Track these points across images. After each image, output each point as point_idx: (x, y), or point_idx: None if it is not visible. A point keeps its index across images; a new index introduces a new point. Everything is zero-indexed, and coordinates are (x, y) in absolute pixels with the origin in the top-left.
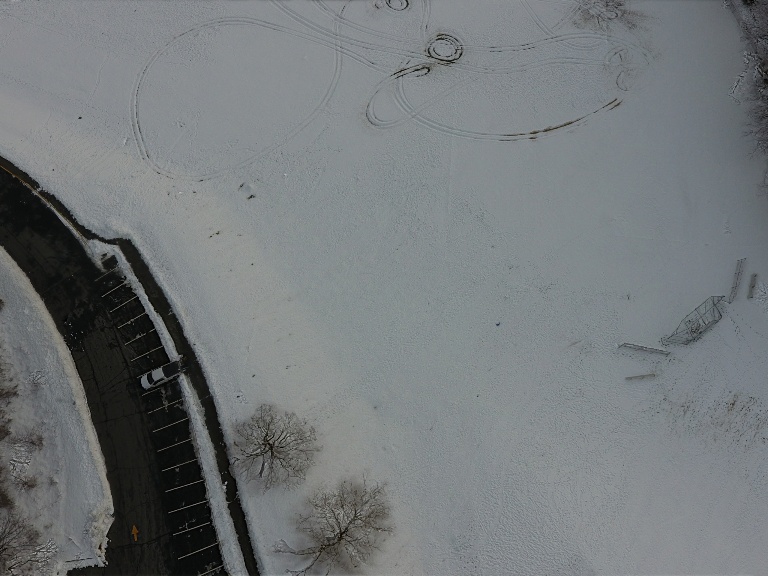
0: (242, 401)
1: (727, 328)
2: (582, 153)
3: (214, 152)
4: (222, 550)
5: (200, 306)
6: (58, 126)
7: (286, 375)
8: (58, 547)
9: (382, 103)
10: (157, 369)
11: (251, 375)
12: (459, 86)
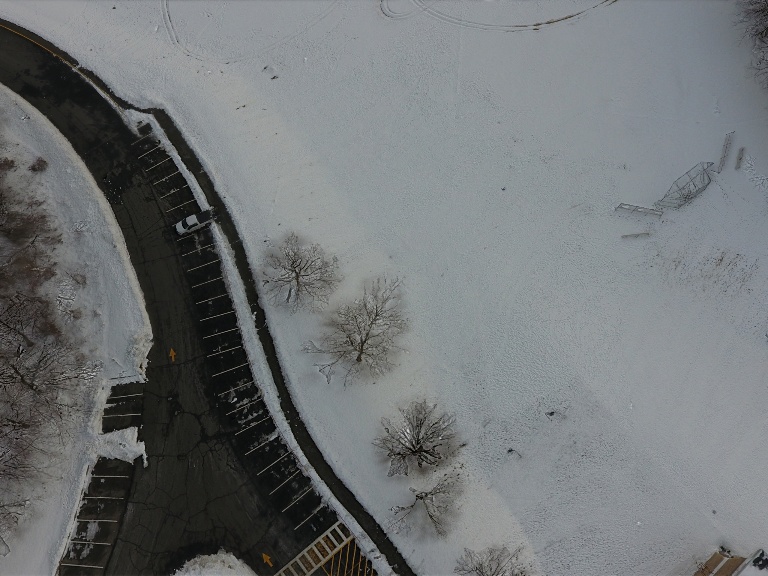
0: (269, 245)
1: (716, 195)
2: (582, 42)
3: (239, 39)
4: (252, 369)
5: (229, 165)
6: (94, 14)
7: (309, 225)
8: (102, 367)
9: None
10: (191, 215)
11: (277, 224)
12: None
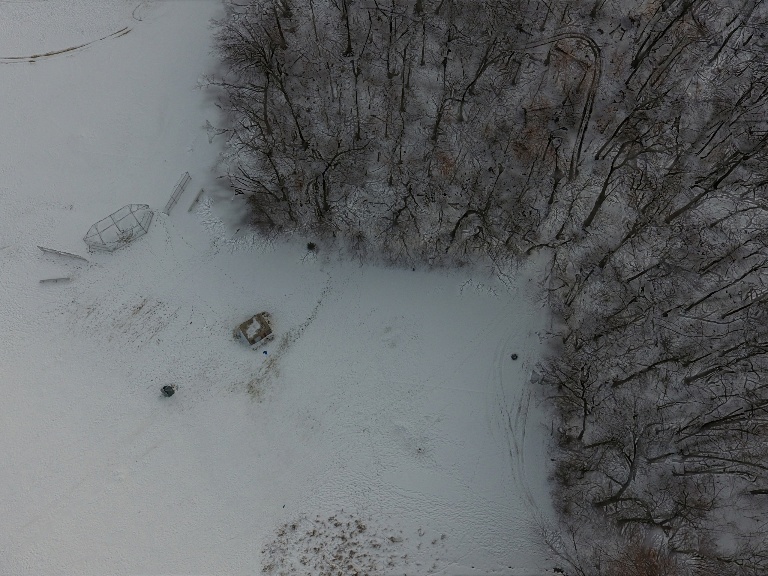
0: None
1: (159, 238)
2: (74, 76)
3: None
4: None
5: None
6: None
7: None
8: None
9: None
10: None
11: None
12: None
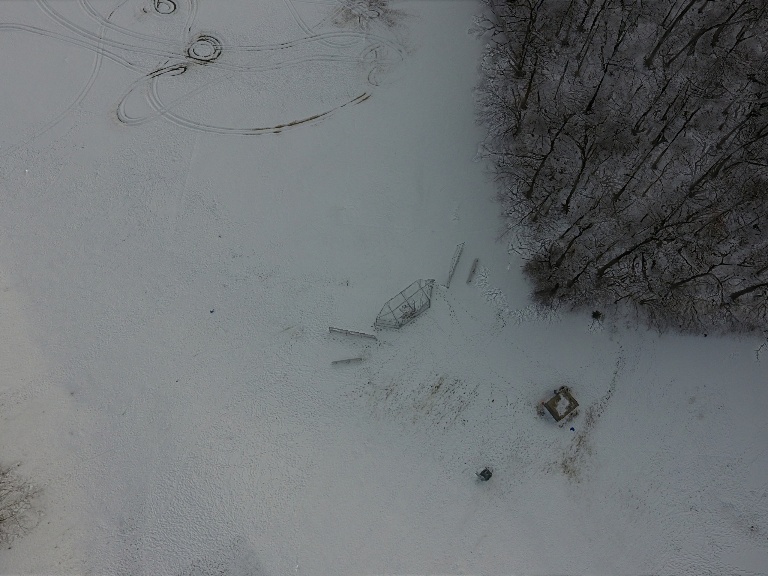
0: None
1: (442, 312)
2: (323, 145)
3: None
4: None
5: None
6: None
7: None
8: None
9: (134, 101)
10: None
11: None
12: (212, 84)
